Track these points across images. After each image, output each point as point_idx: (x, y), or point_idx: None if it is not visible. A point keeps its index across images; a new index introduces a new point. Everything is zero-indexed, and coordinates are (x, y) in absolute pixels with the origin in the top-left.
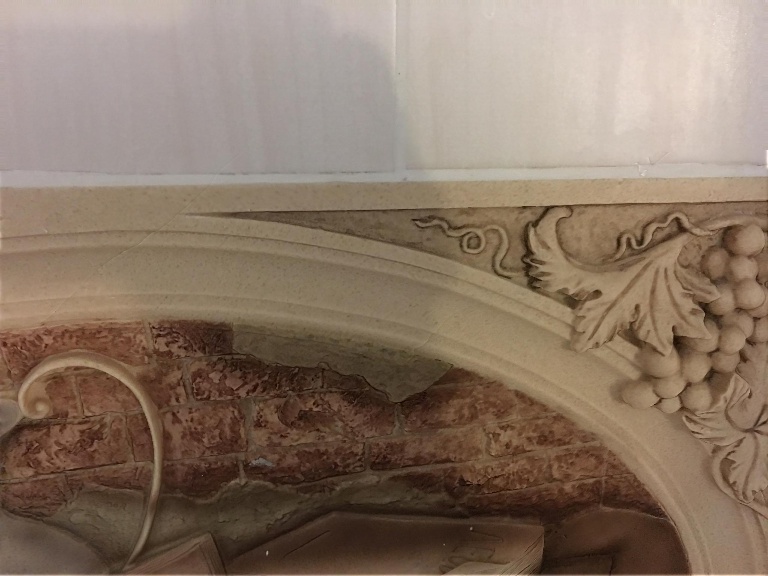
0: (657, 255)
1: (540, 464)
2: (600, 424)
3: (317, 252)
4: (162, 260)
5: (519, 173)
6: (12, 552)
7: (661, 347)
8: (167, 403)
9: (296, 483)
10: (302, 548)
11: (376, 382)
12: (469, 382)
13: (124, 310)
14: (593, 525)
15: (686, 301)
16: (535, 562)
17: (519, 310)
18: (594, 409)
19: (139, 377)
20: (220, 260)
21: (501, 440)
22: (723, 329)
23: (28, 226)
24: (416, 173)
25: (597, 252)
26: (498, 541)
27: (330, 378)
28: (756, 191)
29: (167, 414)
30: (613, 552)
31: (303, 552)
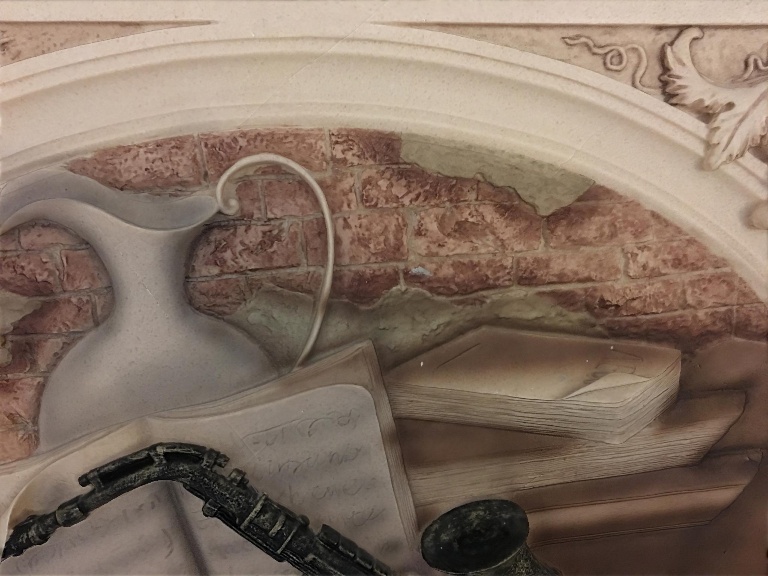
0: None
1: (675, 288)
2: (731, 248)
3: (480, 63)
4: (344, 72)
5: None
6: (197, 345)
7: None
8: (340, 209)
9: (450, 295)
10: (454, 360)
11: (526, 194)
12: (609, 200)
13: (309, 116)
14: (726, 356)
15: None
16: (673, 387)
17: (657, 125)
18: (725, 233)
19: (317, 182)
20: (394, 72)
21: (639, 260)
22: None
23: (239, 30)
24: None
25: (726, 73)
26: (638, 360)
27: (484, 190)
28: None
29: (339, 219)
30: (745, 388)
31: (455, 364)
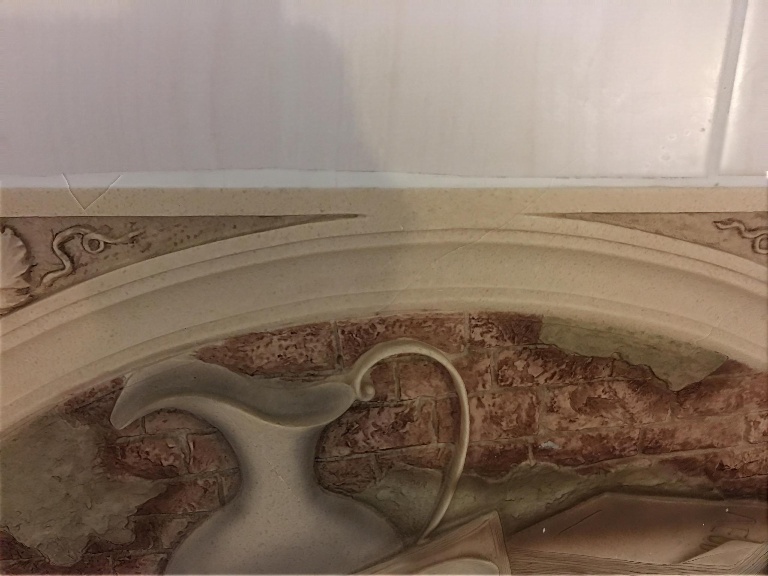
0: None
1: None
2: None
3: (631, 250)
4: (489, 256)
5: None
6: (327, 525)
7: None
8: (474, 389)
9: (576, 465)
10: (576, 526)
11: (660, 372)
12: (739, 373)
13: (450, 302)
14: None
15: None
16: None
17: None
18: None
19: (454, 364)
20: (540, 257)
21: (760, 428)
22: None
23: (387, 223)
24: (727, 179)
25: None
26: (751, 522)
27: (619, 367)
28: None
29: (473, 399)
30: None
31: (577, 530)
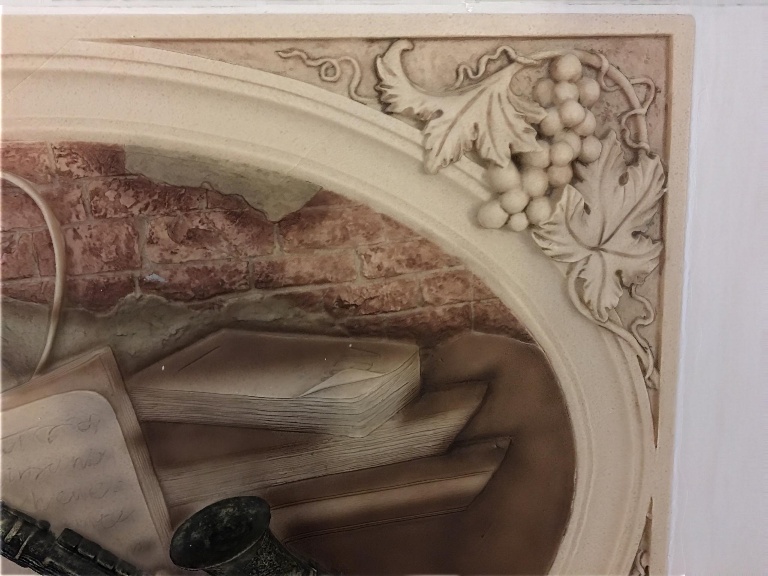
0: (491, 83)
1: (411, 287)
2: (461, 247)
3: (194, 77)
4: (62, 87)
5: (363, 8)
6: None
7: (500, 160)
8: (68, 220)
9: (188, 300)
10: (195, 363)
11: (254, 201)
12: (339, 205)
13: (29, 131)
14: (466, 349)
15: (519, 121)
16: (413, 381)
17: (375, 132)
18: (455, 233)
19: (43, 194)
20: (112, 87)
21: (373, 261)
22: (553, 144)
23: None
24: (274, 7)
25: (440, 82)
26: (376, 357)
27: (213, 198)
28: (570, 26)
29: (69, 230)
30: (489, 379)
31: (196, 366)
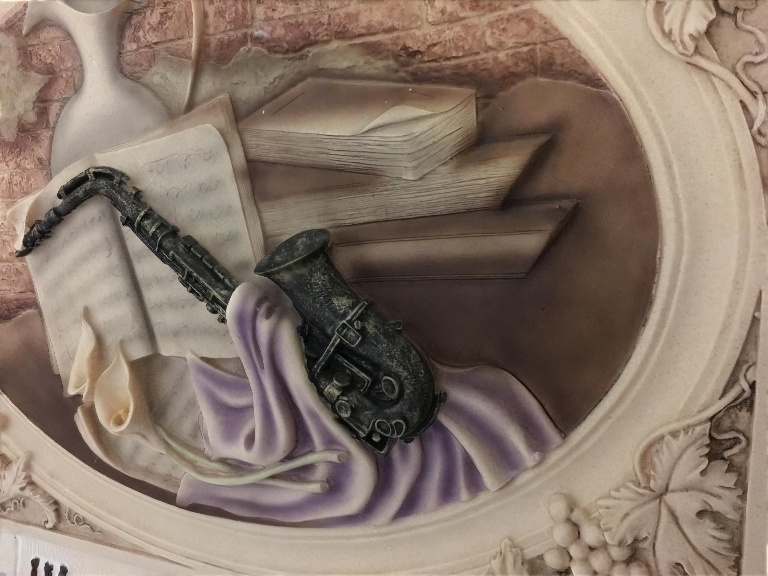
0: None
1: (474, 31)
2: None
3: None
4: None
5: None
6: (121, 100)
7: None
8: None
9: (284, 53)
10: (286, 107)
11: None
12: None
13: None
14: (529, 97)
15: None
16: (468, 127)
17: None
18: None
19: None
20: None
21: (436, 6)
22: None
23: None
24: None
25: None
26: (431, 100)
27: None
28: None
29: None
30: (555, 132)
31: (286, 110)
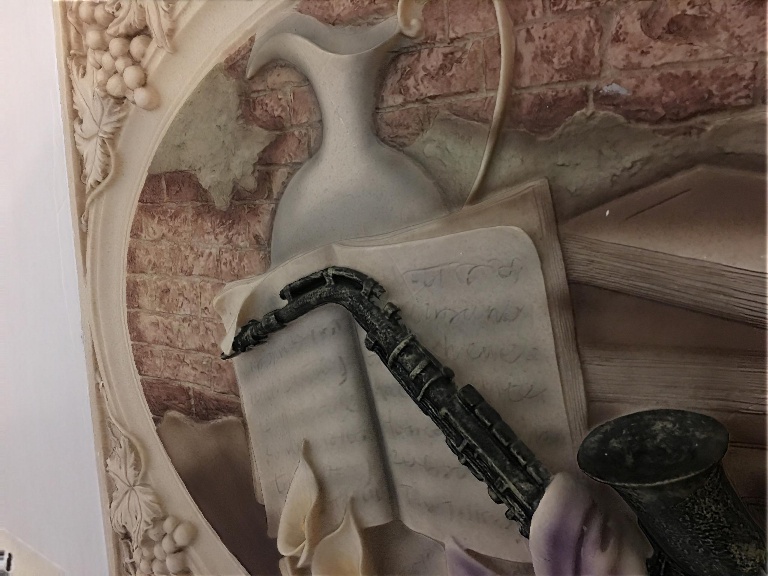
0: None
1: None
2: None
3: None
4: None
5: None
6: (375, 175)
7: None
8: (523, 18)
9: (654, 121)
10: (651, 210)
11: None
12: None
13: None
14: None
15: None
16: None
17: None
18: None
19: None
20: None
21: None
22: None
23: None
24: None
25: None
26: None
27: None
28: None
29: (522, 31)
30: None
31: (651, 215)
